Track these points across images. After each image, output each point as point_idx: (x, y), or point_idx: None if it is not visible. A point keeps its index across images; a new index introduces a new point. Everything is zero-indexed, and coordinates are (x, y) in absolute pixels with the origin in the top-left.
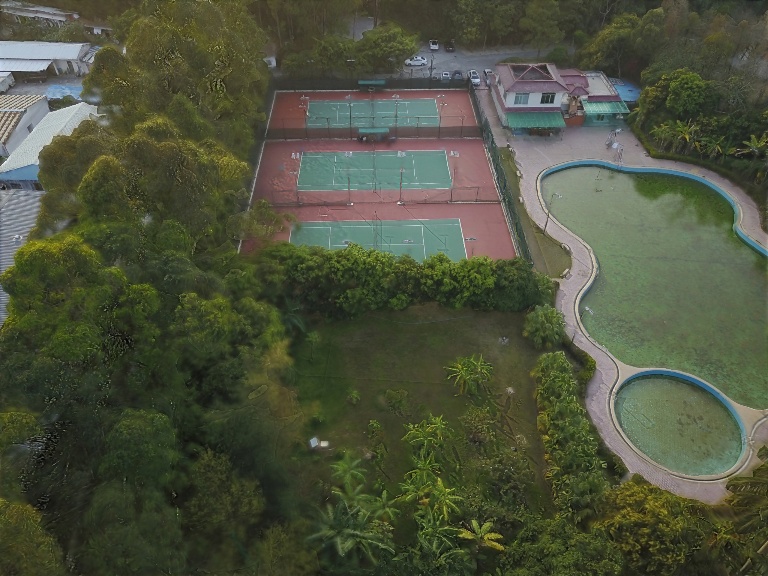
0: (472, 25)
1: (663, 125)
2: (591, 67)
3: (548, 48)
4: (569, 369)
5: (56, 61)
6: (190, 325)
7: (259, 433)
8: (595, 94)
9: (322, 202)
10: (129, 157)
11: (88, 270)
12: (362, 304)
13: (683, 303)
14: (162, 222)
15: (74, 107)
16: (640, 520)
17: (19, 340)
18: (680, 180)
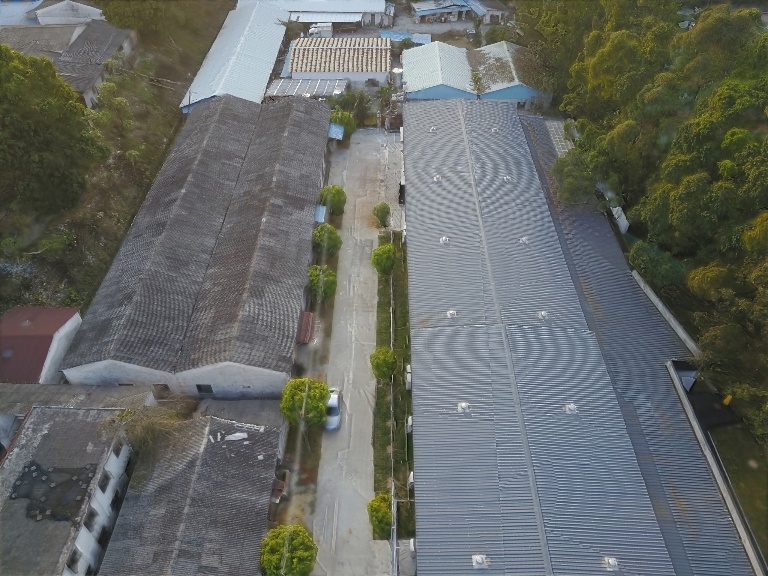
0: None
1: None
2: None
3: (760, 7)
4: None
5: (365, 14)
6: None
7: None
8: None
9: None
10: None
11: None
12: None
13: None
14: None
15: (431, 45)
16: None
17: None
18: None
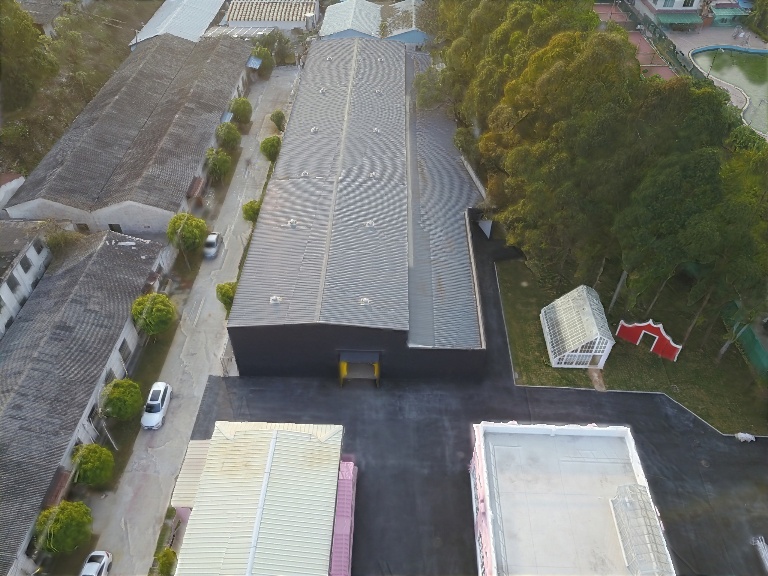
0: None
1: None
2: None
3: None
4: None
5: None
6: None
7: None
8: (721, 2)
9: None
10: None
11: None
12: None
13: None
14: None
15: (351, 0)
16: None
17: None
18: None
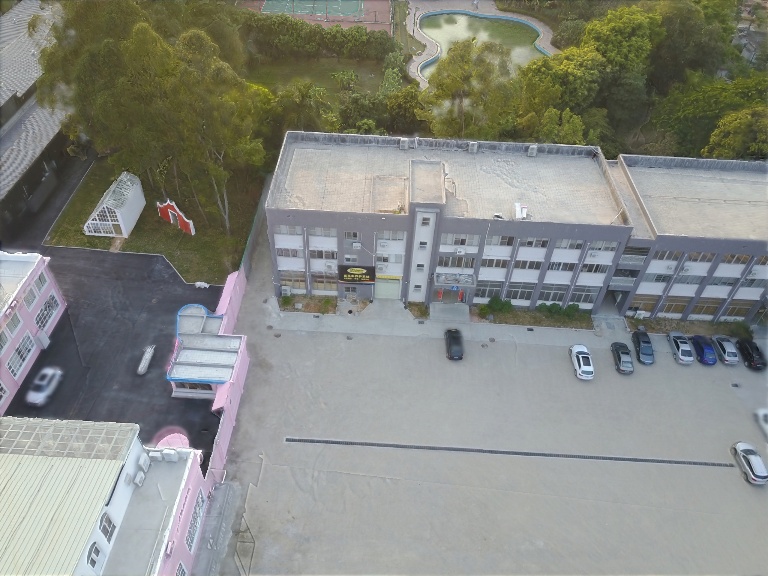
0: None
1: None
2: None
3: None
4: None
5: None
6: None
7: (222, 34)
8: None
9: None
10: None
11: None
12: (289, 46)
13: None
14: None
15: None
16: (400, 94)
17: None
18: (513, 22)
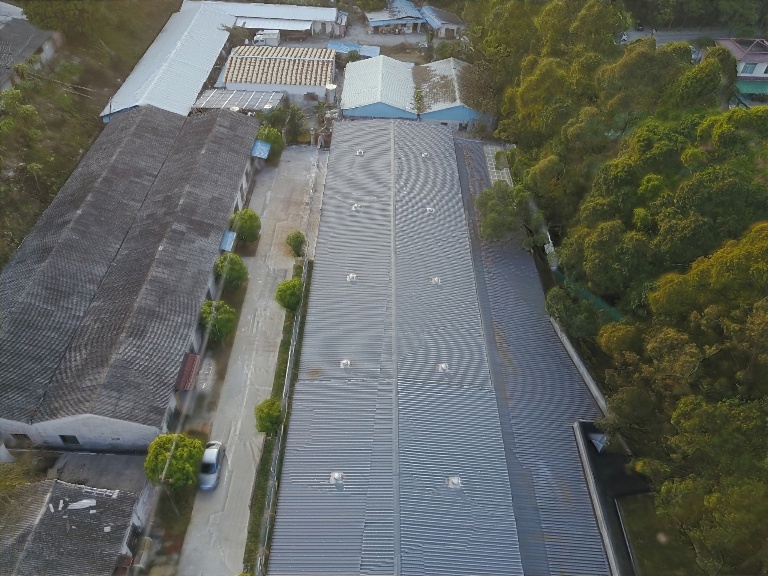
0: (666, 7)
1: None
2: None
3: (723, 31)
4: None
5: (315, 22)
6: None
7: None
8: None
9: None
10: (719, 62)
11: None
12: None
13: None
14: None
15: (376, 59)
16: None
17: None
18: None
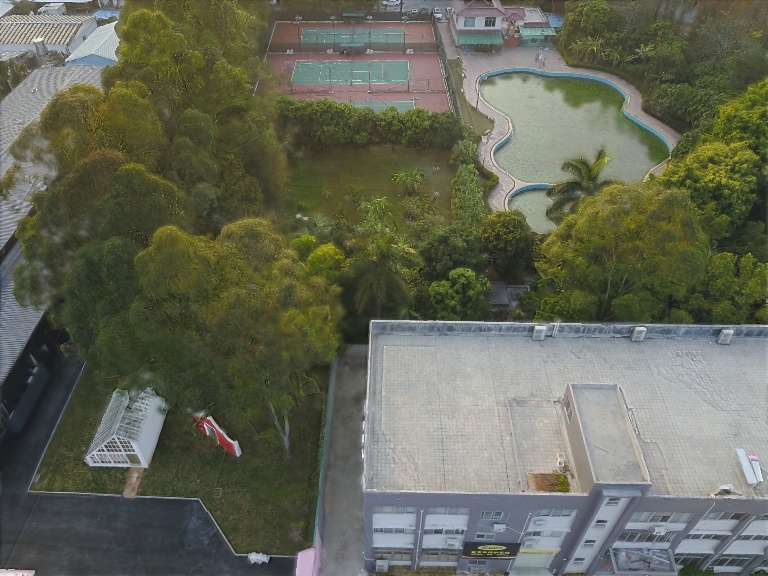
0: None
1: (578, 41)
2: (531, 4)
3: None
4: (476, 175)
5: None
6: (222, 75)
7: (261, 155)
8: (530, 21)
9: (310, 90)
10: None
11: (167, 31)
12: (335, 138)
13: (572, 151)
14: (203, 31)
15: None
16: (496, 220)
17: (130, 65)
18: (589, 81)
